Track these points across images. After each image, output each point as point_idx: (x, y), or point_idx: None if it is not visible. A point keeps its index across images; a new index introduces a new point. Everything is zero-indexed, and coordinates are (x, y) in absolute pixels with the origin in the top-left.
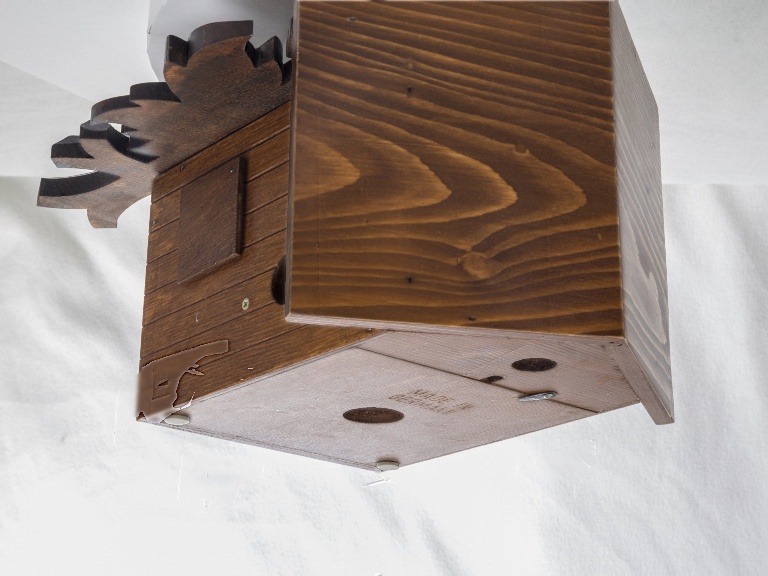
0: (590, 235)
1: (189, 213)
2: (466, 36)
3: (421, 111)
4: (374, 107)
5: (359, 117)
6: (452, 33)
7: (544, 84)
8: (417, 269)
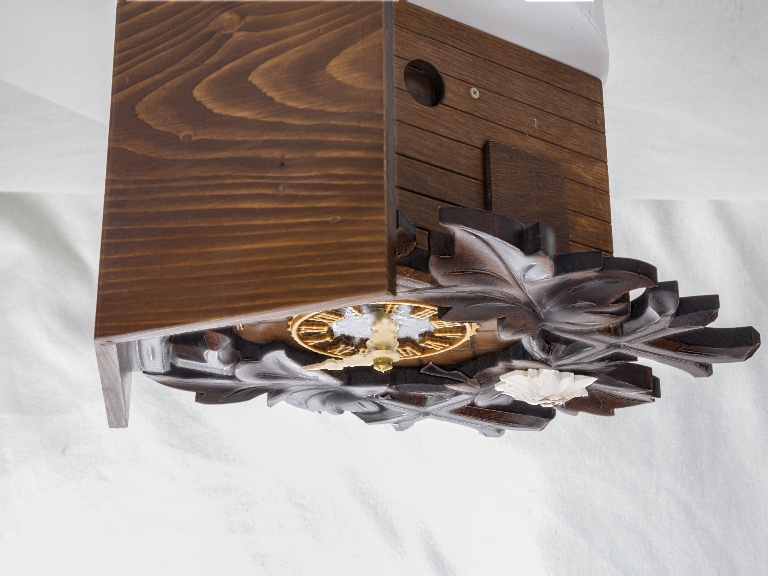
0: (135, 79)
1: (555, 224)
2: (229, 234)
3: (272, 146)
4: (314, 136)
5: (327, 122)
6: (242, 234)
7: (162, 207)
8: (278, 3)
